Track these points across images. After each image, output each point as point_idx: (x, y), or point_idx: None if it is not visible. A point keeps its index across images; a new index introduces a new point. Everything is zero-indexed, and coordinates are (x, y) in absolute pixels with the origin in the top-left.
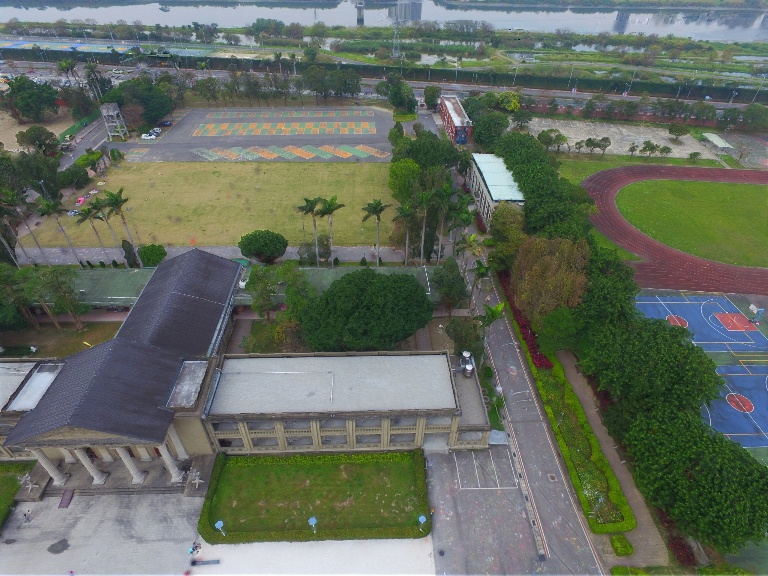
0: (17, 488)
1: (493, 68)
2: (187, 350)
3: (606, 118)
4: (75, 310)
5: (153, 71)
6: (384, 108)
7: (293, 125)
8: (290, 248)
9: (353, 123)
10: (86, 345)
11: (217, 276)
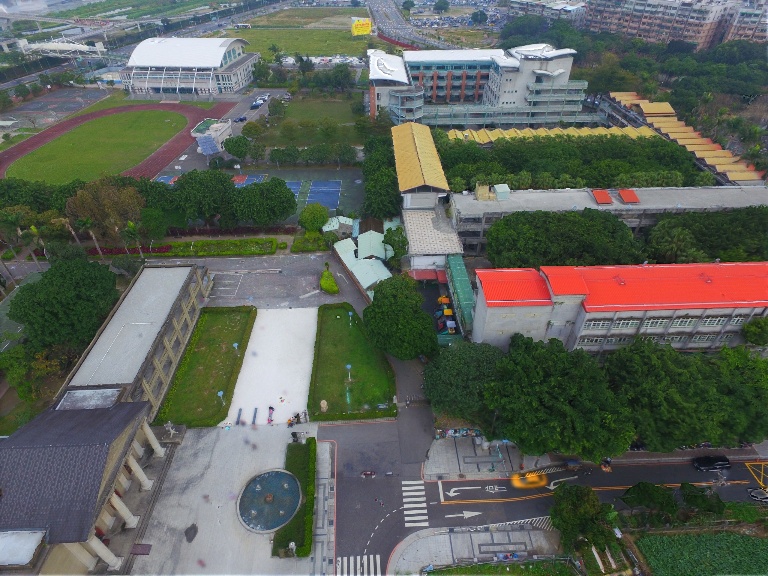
0: None
1: None
2: None
3: None
4: None
5: None
6: None
7: None
8: None
9: None
10: None
11: None
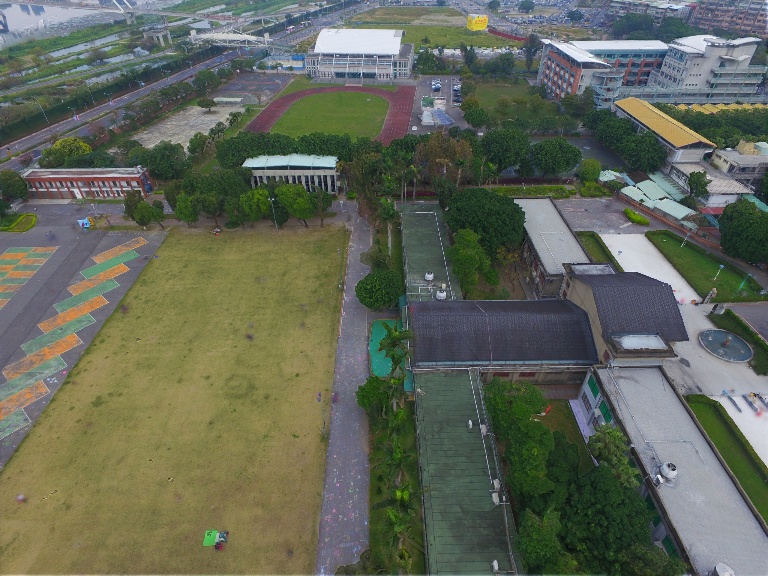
0: None
1: None
2: None
3: (145, 123)
4: None
5: None
6: None
7: None
8: (347, 297)
9: None
10: None
11: None
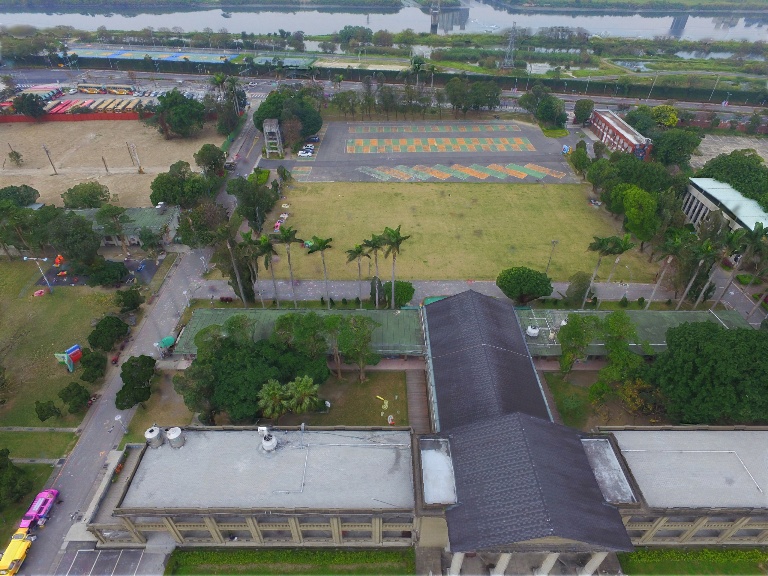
0: None
1: (619, 78)
2: (534, 416)
3: None
4: None
5: (268, 82)
6: (527, 122)
7: (444, 141)
8: None
9: (505, 139)
10: (379, 399)
11: (504, 322)
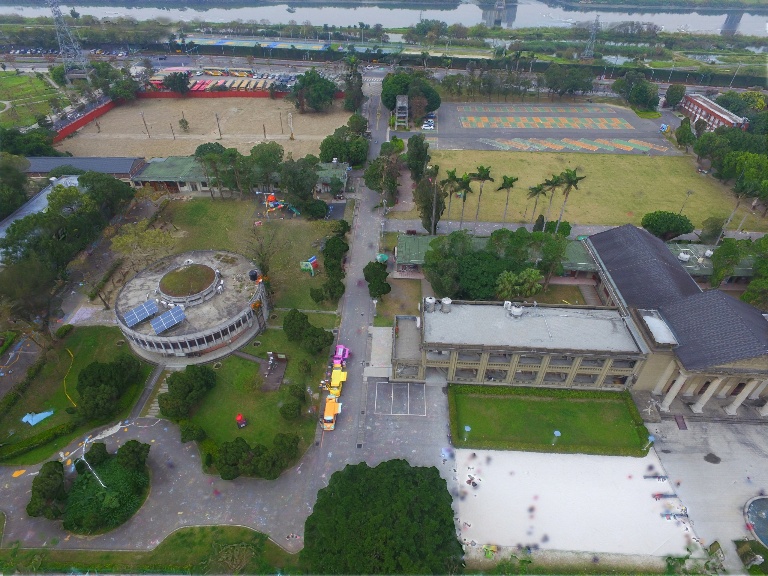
0: (636, 411)
1: (699, 69)
2: None
3: None
4: (557, 271)
5: None
6: (619, 105)
7: (548, 119)
8: None
9: (603, 119)
10: (564, 302)
11: (661, 248)
